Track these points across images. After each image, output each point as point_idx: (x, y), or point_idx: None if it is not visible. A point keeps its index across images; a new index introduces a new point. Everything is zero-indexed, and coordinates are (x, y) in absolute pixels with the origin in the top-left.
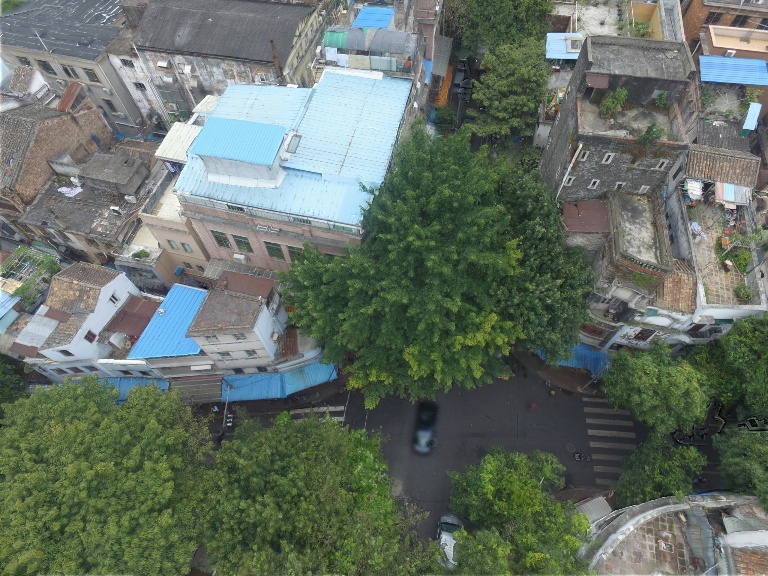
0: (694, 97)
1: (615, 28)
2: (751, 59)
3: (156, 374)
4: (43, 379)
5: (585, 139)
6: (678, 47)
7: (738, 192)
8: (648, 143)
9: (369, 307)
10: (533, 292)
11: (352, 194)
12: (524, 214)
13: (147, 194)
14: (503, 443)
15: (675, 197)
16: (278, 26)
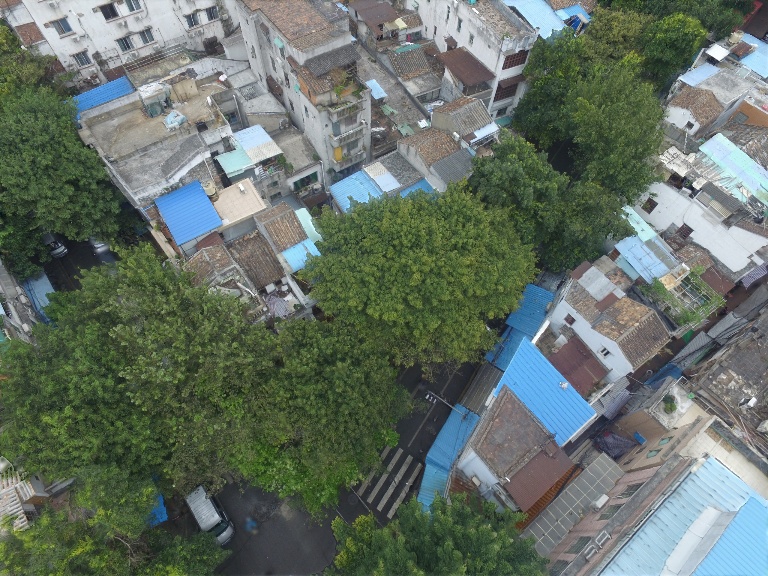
0: None
1: None
2: None
3: None
4: None
5: None
6: None
7: None
8: None
9: None
10: None
11: None
12: None
13: None
14: None
15: None
16: None
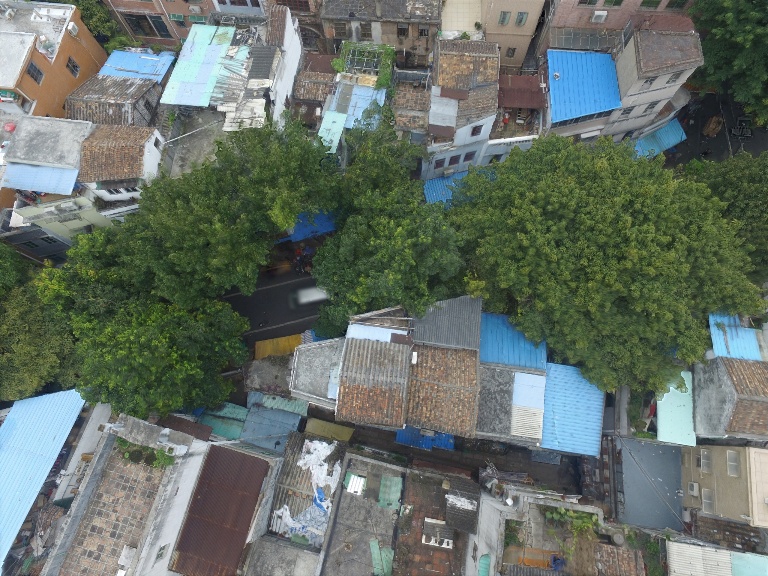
0: None
1: None
2: None
3: None
4: (416, 177)
5: None
6: None
7: None
8: None
9: None
10: None
11: None
12: None
13: None
14: None
15: None
16: None
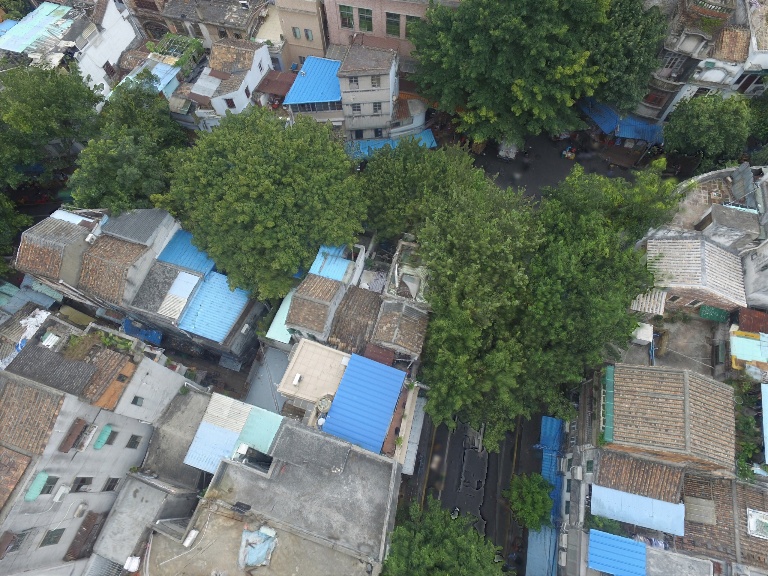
0: None
1: None
2: None
3: None
4: None
5: None
6: None
7: None
8: None
9: (496, 31)
10: (617, 39)
11: None
12: None
13: None
14: None
15: None
16: None
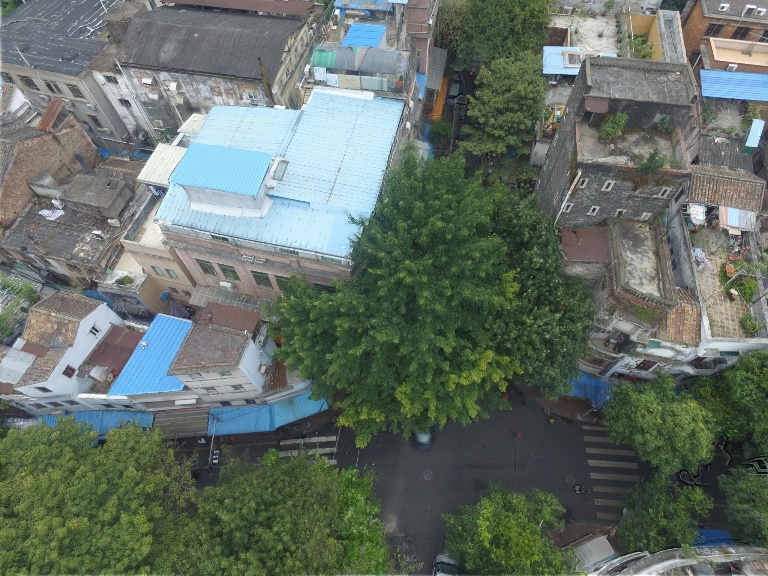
0: (695, 112)
1: (613, 41)
2: (753, 73)
3: (139, 407)
4: (22, 413)
5: (584, 167)
6: (680, 69)
7: (743, 217)
8: (650, 172)
9: (358, 348)
10: (531, 326)
11: (341, 224)
12: (521, 243)
13: (131, 216)
14: (501, 475)
15: (677, 221)
16: (266, 42)
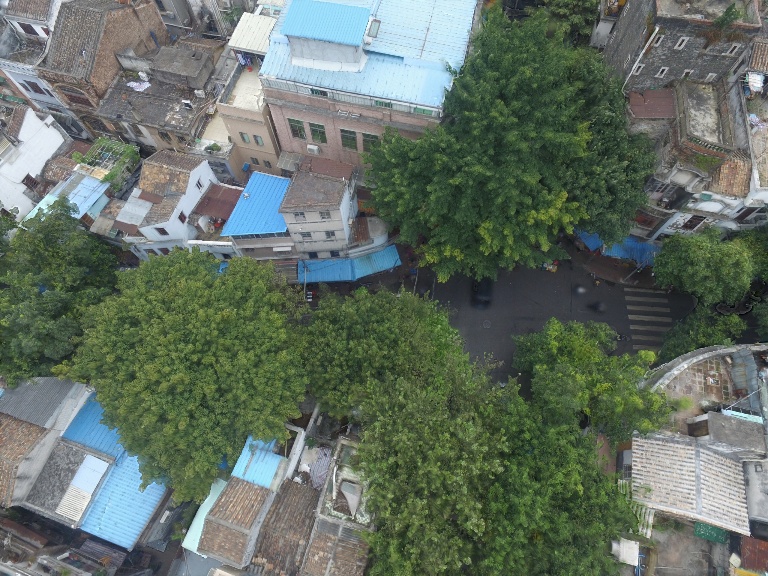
0: None
1: None
2: None
3: None
4: (135, 260)
5: (663, 22)
6: None
7: None
8: (725, 25)
9: (457, 179)
10: (600, 174)
11: (433, 78)
12: (593, 101)
13: (213, 90)
14: None
15: (734, 91)
16: None
